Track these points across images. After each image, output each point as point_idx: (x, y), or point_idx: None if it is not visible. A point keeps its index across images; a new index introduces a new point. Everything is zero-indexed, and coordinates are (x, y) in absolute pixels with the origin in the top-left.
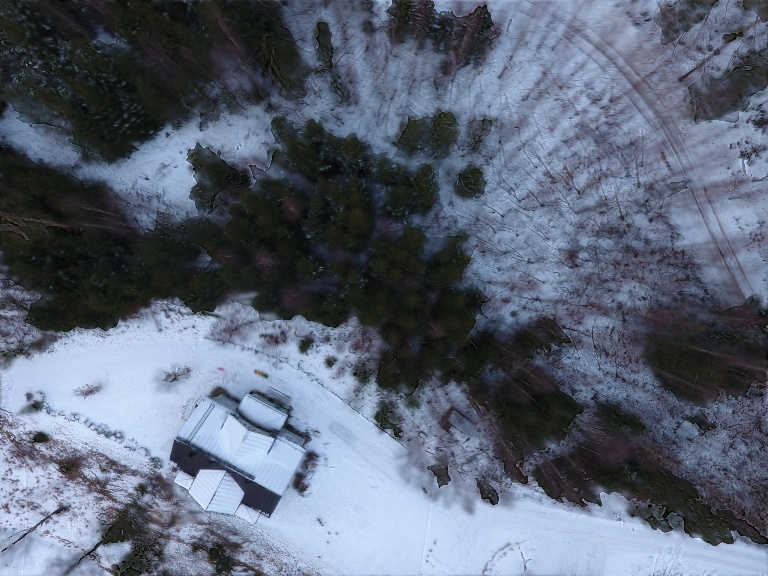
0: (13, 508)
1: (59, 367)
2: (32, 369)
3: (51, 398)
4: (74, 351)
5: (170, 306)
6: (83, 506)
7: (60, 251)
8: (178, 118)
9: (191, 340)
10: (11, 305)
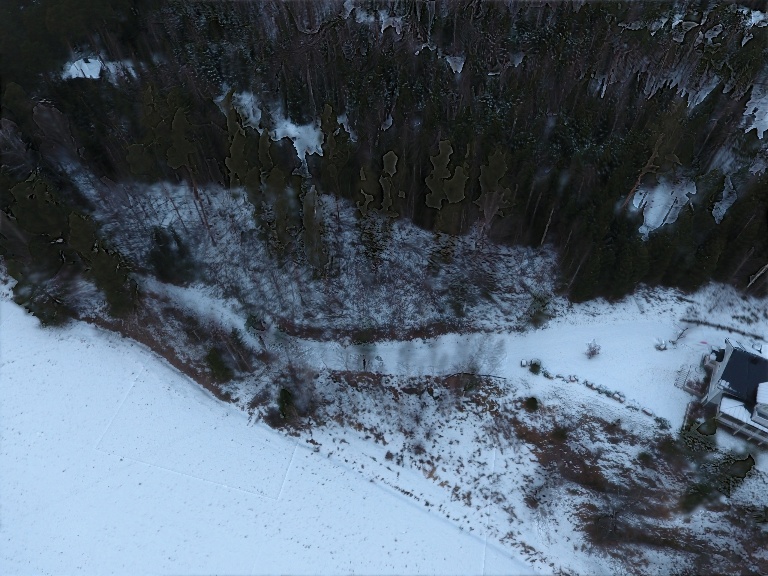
0: (476, 498)
1: (552, 340)
2: (525, 343)
3: (546, 364)
4: (565, 328)
5: (651, 294)
6: (553, 501)
7: (608, 228)
8: (656, 181)
9: (669, 322)
10: (520, 289)
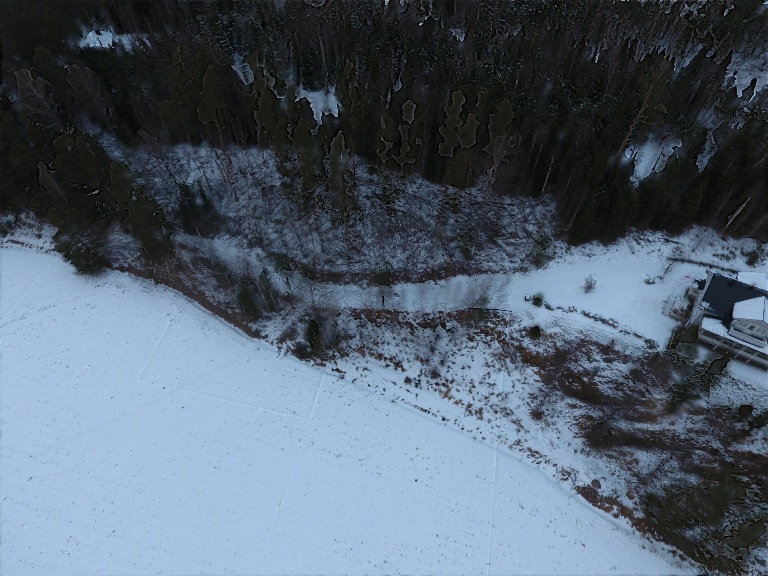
0: (487, 413)
1: (552, 278)
2: (528, 281)
3: (548, 298)
4: (564, 268)
5: (641, 236)
6: (555, 414)
7: (602, 176)
8: None
9: (657, 260)
10: (523, 235)
